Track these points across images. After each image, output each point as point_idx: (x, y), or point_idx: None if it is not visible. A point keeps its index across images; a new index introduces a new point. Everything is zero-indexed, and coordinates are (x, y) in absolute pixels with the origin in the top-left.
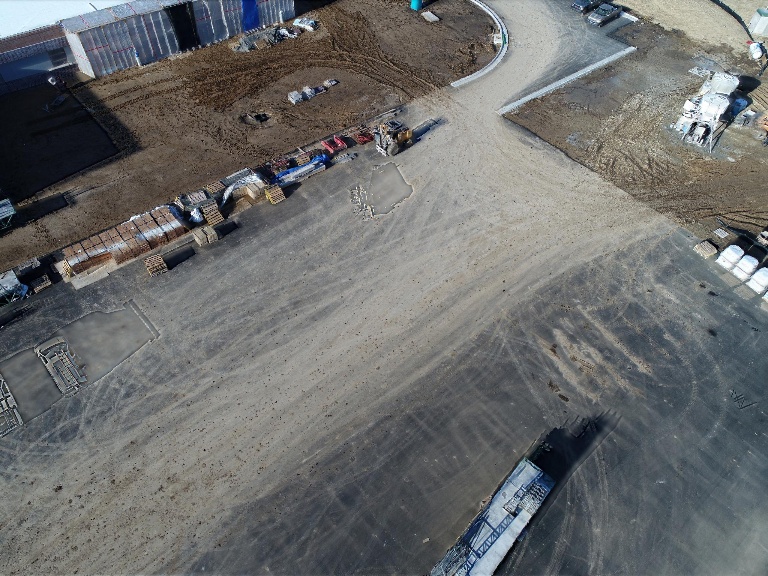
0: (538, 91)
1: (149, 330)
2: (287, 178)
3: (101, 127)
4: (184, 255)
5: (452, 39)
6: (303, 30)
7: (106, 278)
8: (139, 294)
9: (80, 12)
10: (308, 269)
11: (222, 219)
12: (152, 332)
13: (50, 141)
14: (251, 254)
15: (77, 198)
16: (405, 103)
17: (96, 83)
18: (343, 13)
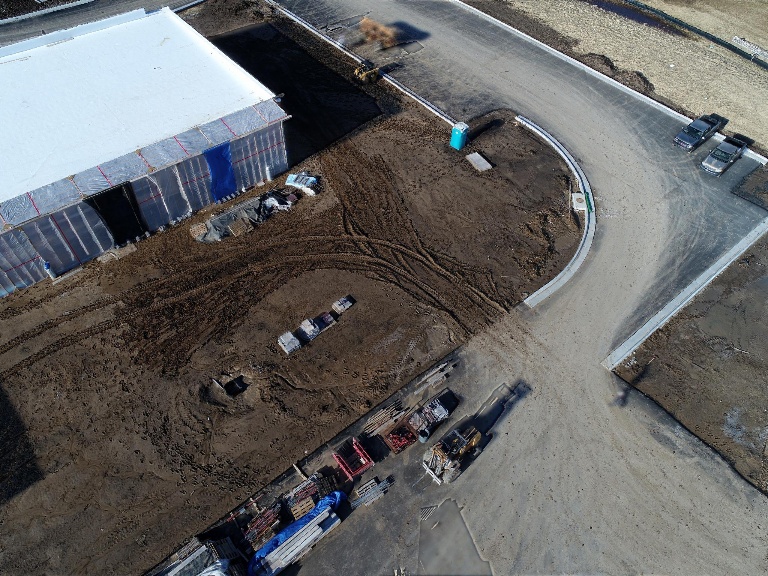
0: (658, 314)
1: None
2: (275, 561)
3: None
4: None
5: (514, 204)
6: (300, 194)
7: None
8: None
9: None
10: None
11: None
12: None
13: None
14: None
15: None
16: (459, 346)
17: None
18: (356, 158)
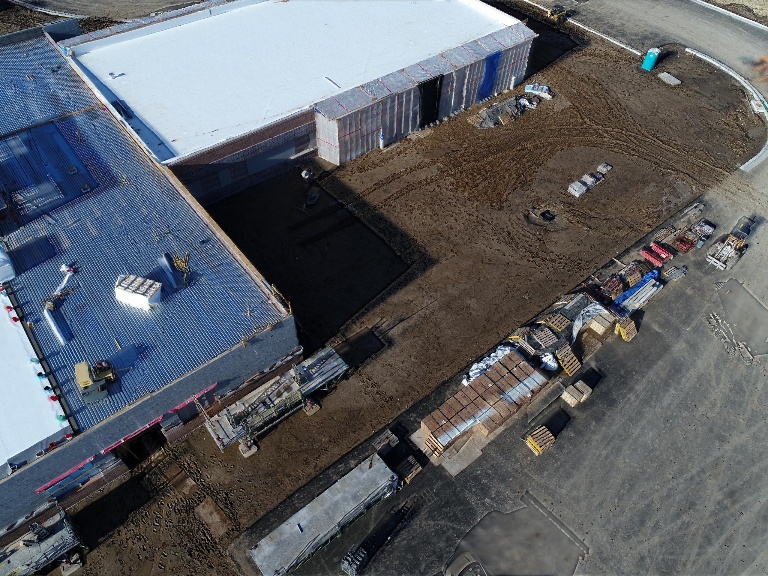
0: None
1: (572, 540)
2: (630, 305)
3: (374, 232)
4: (558, 420)
5: (707, 107)
6: (539, 98)
7: (481, 457)
8: (533, 482)
9: (321, 89)
10: (719, 440)
11: (579, 365)
12: (577, 544)
13: (324, 253)
14: (638, 417)
15: (391, 335)
16: (702, 194)
17: (342, 172)
18: (571, 75)
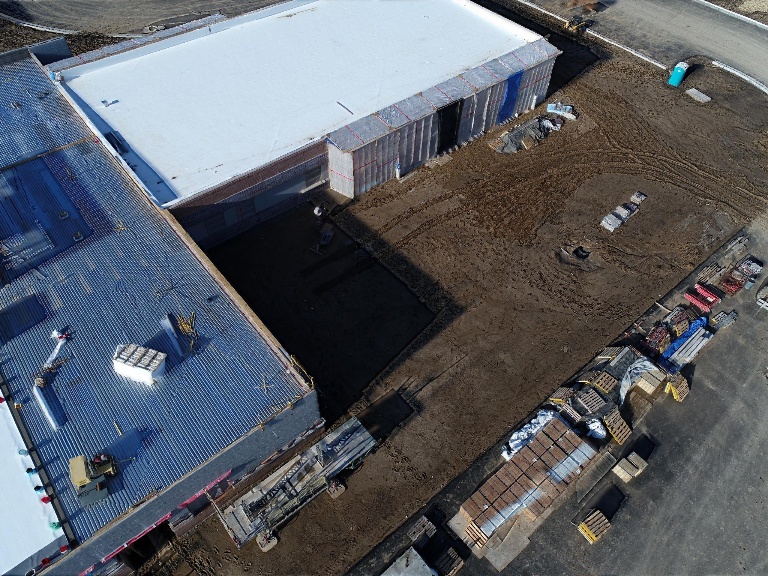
0: None
1: None
2: (679, 359)
3: (395, 276)
4: (612, 499)
5: (741, 127)
6: (563, 119)
7: (529, 547)
8: None
9: (332, 116)
10: None
11: (630, 432)
12: None
13: (342, 301)
14: (699, 494)
15: (419, 398)
16: (745, 226)
17: (357, 206)
18: (595, 93)
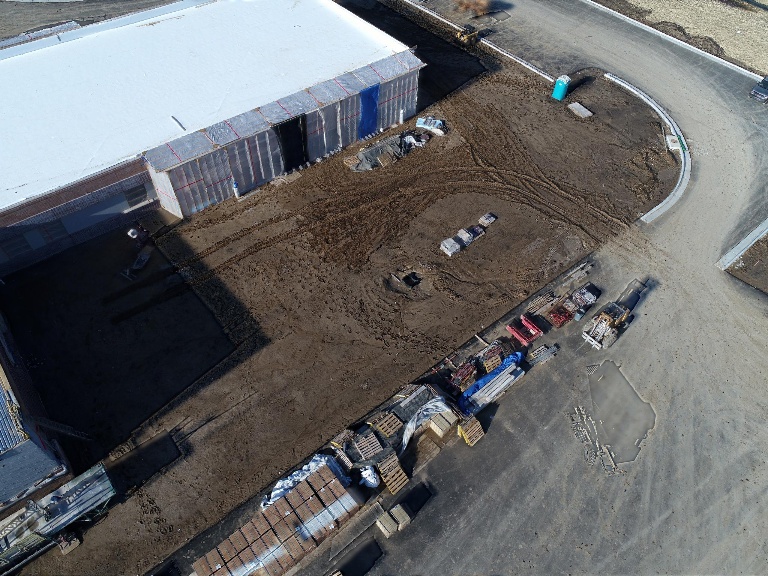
0: (757, 229)
1: None
2: (480, 398)
3: (204, 304)
4: (367, 557)
5: (617, 144)
6: (430, 134)
7: None
8: None
9: (162, 132)
10: None
11: (406, 480)
12: None
13: (139, 331)
14: (464, 551)
15: (191, 440)
16: (593, 252)
17: (185, 227)
18: (472, 106)
